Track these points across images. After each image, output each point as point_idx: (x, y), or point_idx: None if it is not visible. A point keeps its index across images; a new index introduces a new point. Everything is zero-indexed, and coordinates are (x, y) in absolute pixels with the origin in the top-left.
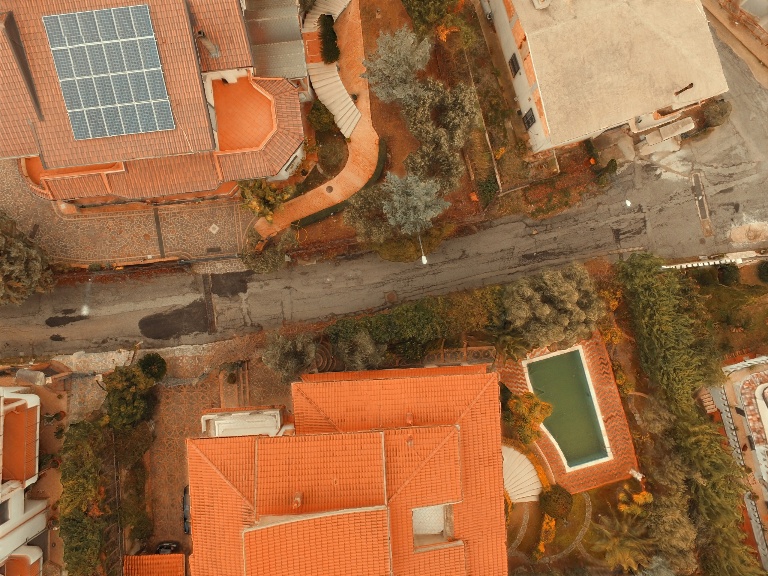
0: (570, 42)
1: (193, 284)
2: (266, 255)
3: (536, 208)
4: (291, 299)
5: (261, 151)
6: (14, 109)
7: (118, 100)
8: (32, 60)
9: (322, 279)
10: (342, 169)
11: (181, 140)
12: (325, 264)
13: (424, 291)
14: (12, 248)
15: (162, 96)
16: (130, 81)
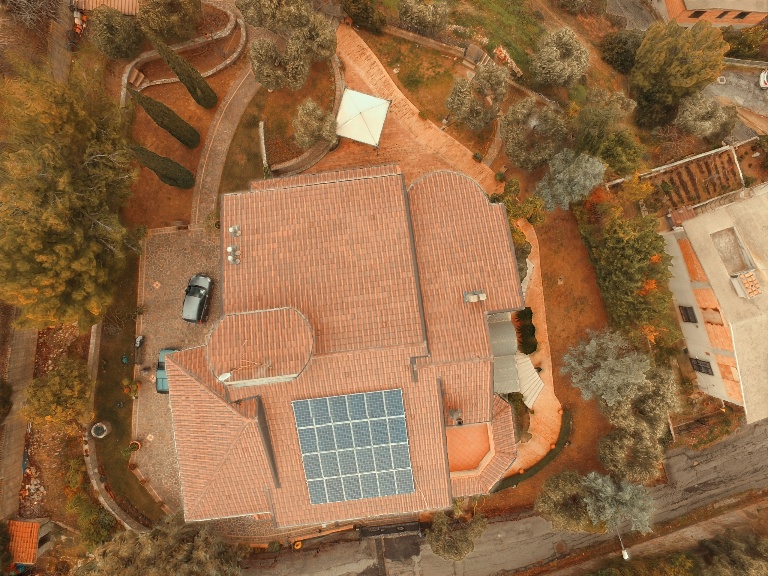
0: None
1: (366, 549)
2: (458, 546)
3: (698, 440)
4: (463, 559)
5: (478, 476)
6: (252, 480)
7: (360, 470)
8: (275, 436)
9: (493, 536)
10: None
11: (418, 500)
12: (496, 520)
13: (591, 537)
14: (219, 575)
15: (405, 465)
16: (374, 453)
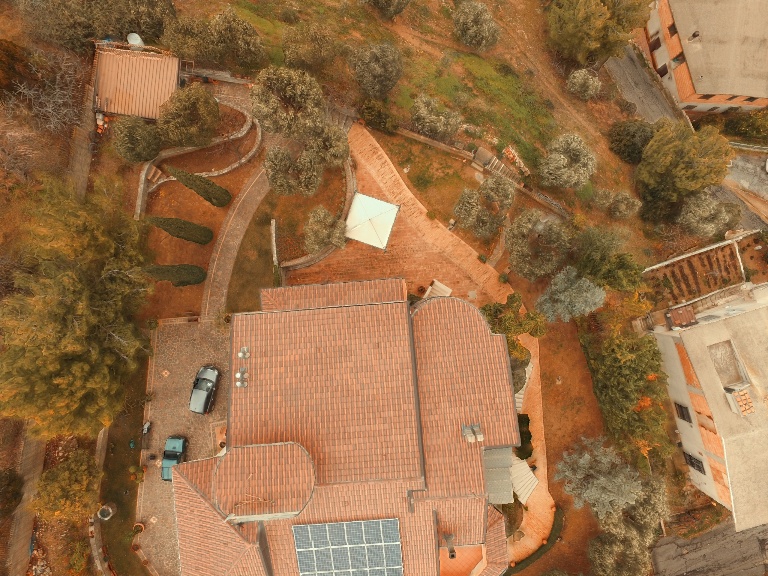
0: (766, 445)
1: None
2: None
3: (688, 530)
4: None
5: None
6: None
7: None
8: (275, 555)
9: None
10: (515, 530)
11: None
12: None
13: None
14: None
15: None
16: (370, 575)
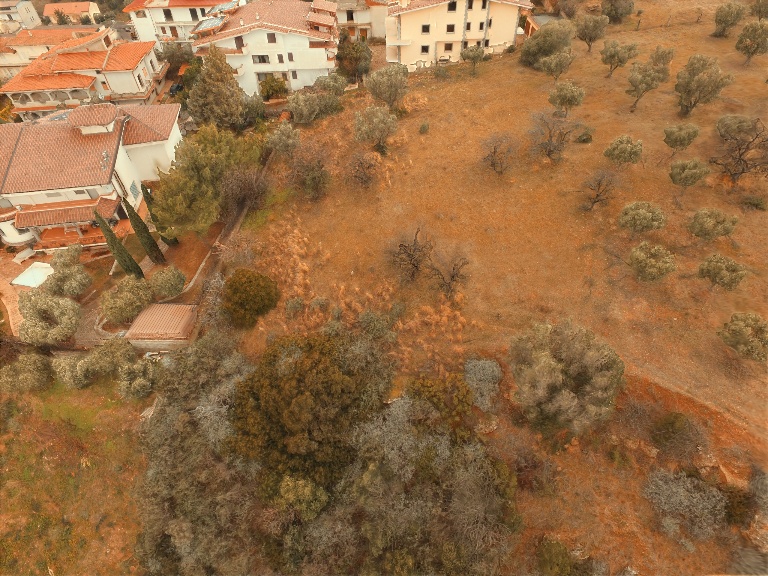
0: None
1: None
2: None
3: None
4: None
5: None
6: None
7: None
8: None
9: None
10: None
11: None
12: None
13: None
14: None
15: None
16: None
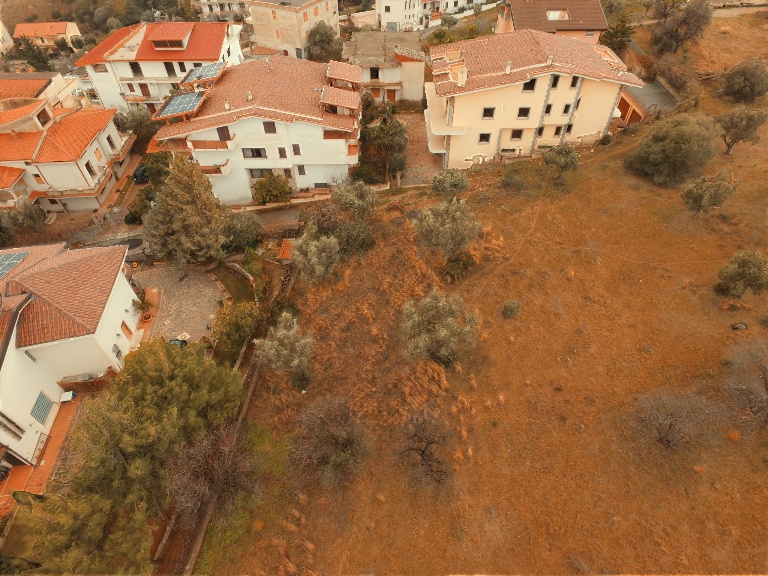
0: None
1: None
2: None
3: None
4: None
5: None
6: None
7: None
8: None
9: None
10: None
11: None
12: None
13: None
14: None
15: None
16: None
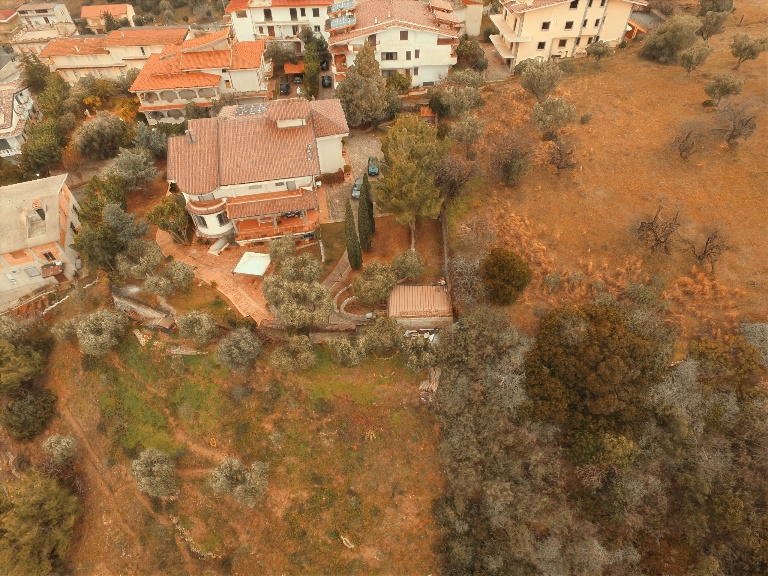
0: None
1: None
2: None
3: None
4: None
5: None
6: None
7: None
8: None
9: None
10: None
11: None
12: None
13: None
14: None
15: None
16: None
